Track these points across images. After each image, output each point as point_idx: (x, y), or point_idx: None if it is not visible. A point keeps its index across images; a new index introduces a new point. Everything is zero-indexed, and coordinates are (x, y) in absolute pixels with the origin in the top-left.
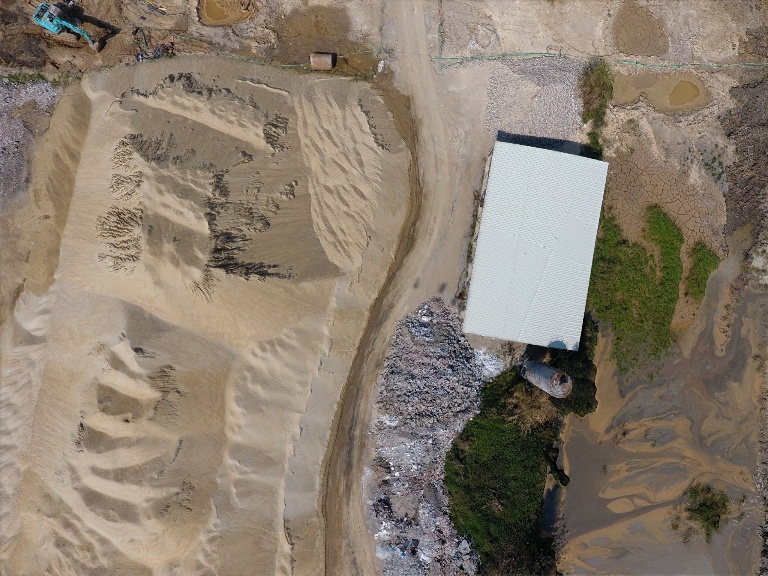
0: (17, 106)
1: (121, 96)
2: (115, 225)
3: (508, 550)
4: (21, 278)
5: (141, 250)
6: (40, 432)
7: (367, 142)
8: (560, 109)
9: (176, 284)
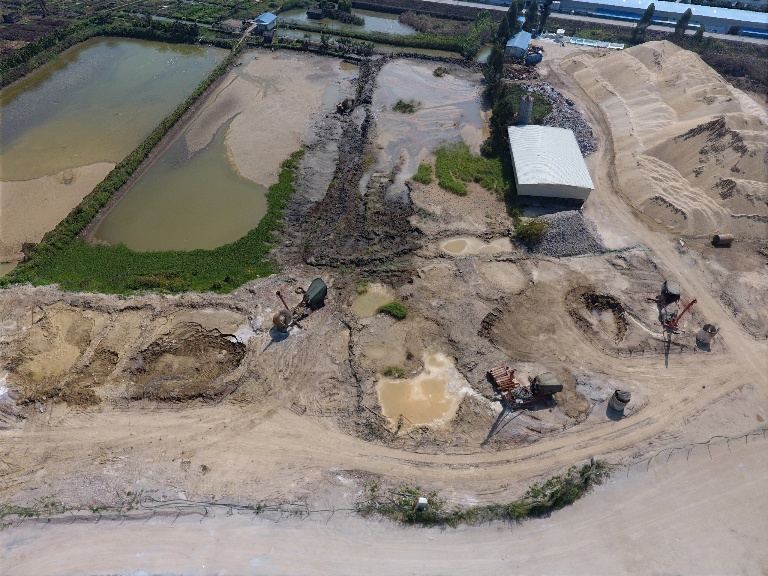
0: None
1: None
2: None
3: None
4: None
5: None
6: None
7: None
8: None
9: None
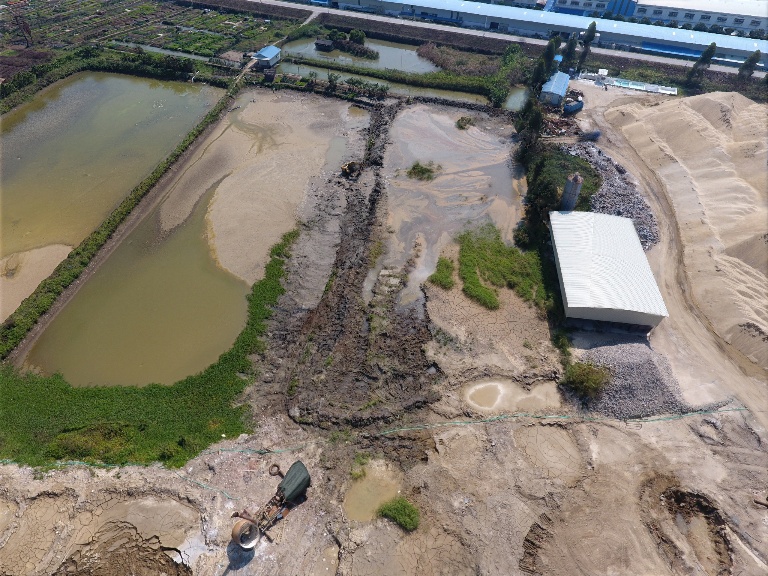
0: None
1: None
2: None
3: None
4: None
5: None
6: None
7: (764, 327)
8: None
9: None
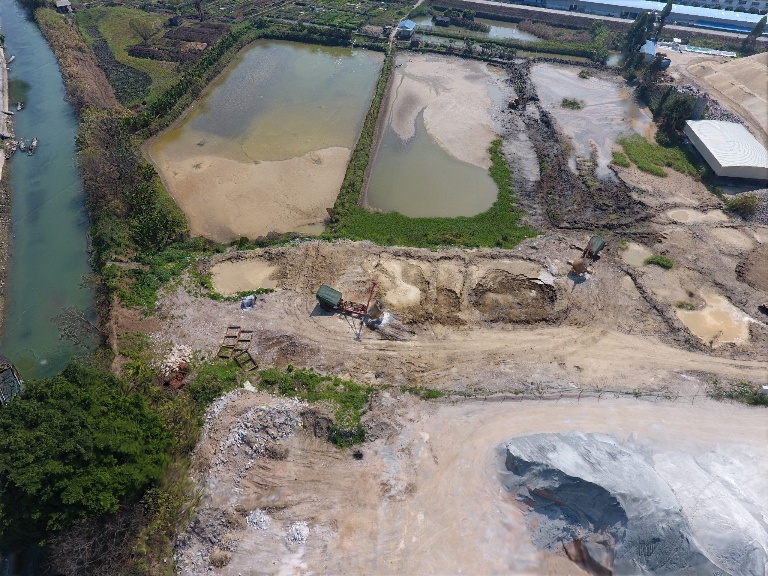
0: None
1: None
2: None
3: None
4: None
5: None
6: None
7: None
8: None
9: None
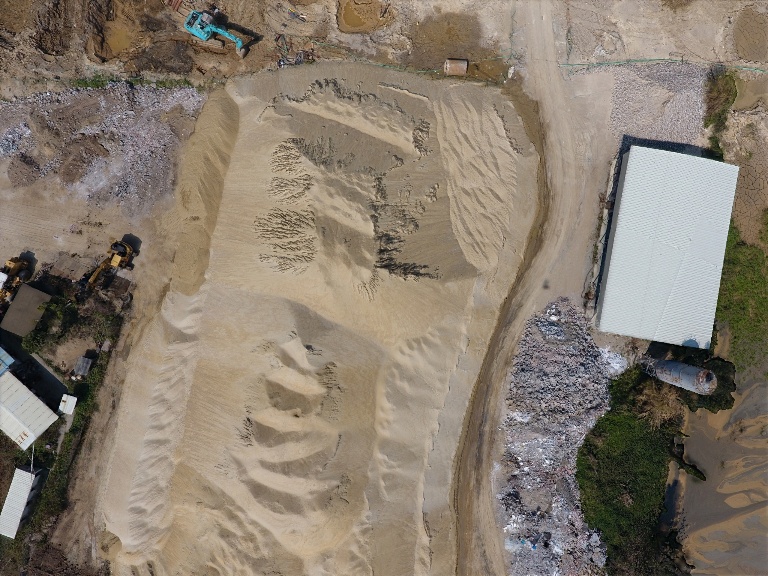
0: (164, 111)
1: (273, 101)
2: (280, 227)
3: (636, 543)
4: (167, 278)
5: (316, 251)
6: (195, 427)
7: (503, 146)
8: (688, 114)
9: (345, 284)
